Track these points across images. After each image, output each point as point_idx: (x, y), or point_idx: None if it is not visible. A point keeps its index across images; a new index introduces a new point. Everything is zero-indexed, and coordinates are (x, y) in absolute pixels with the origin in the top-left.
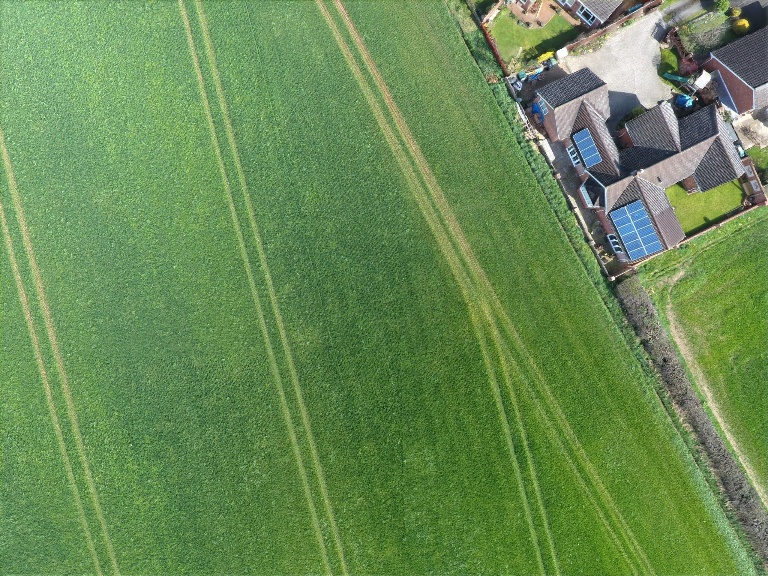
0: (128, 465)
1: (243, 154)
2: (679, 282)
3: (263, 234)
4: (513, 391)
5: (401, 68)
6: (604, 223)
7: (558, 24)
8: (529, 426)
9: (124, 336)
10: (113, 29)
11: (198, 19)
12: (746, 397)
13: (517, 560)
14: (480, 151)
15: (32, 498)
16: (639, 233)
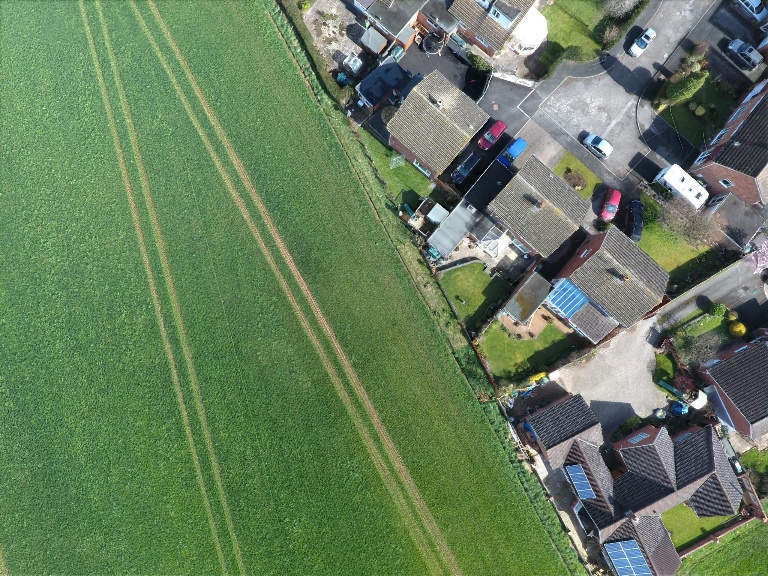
0: None
1: (229, 493)
2: None
3: (250, 575)
4: None
5: (390, 390)
6: None
7: (550, 334)
8: None
9: None
10: (95, 370)
11: (182, 353)
12: None
13: None
14: (471, 472)
15: None
16: (634, 570)
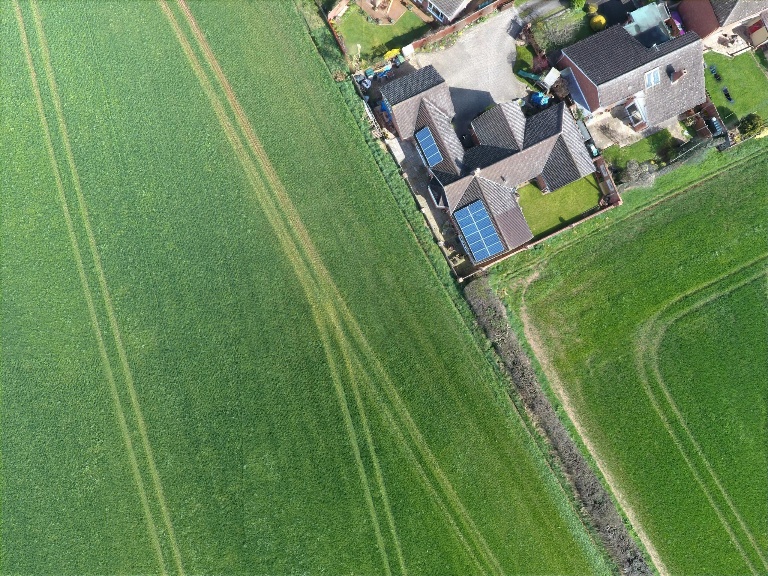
0: None
1: (76, 153)
2: (533, 283)
3: (97, 235)
4: (359, 395)
5: (245, 65)
6: (453, 223)
7: (409, 21)
8: (375, 430)
9: None
10: None
11: (32, 15)
12: (603, 401)
13: (363, 567)
14: (326, 150)
15: None
16: (481, 234)
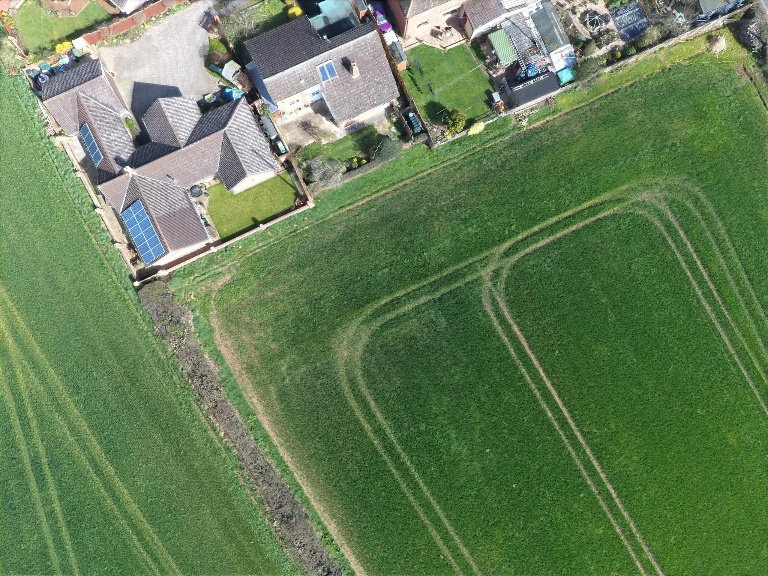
0: None
1: None
2: (223, 287)
3: None
4: (30, 404)
5: None
6: None
7: (93, 13)
8: (47, 442)
9: None
10: None
11: None
12: (301, 409)
13: None
14: None
15: None
16: (145, 235)
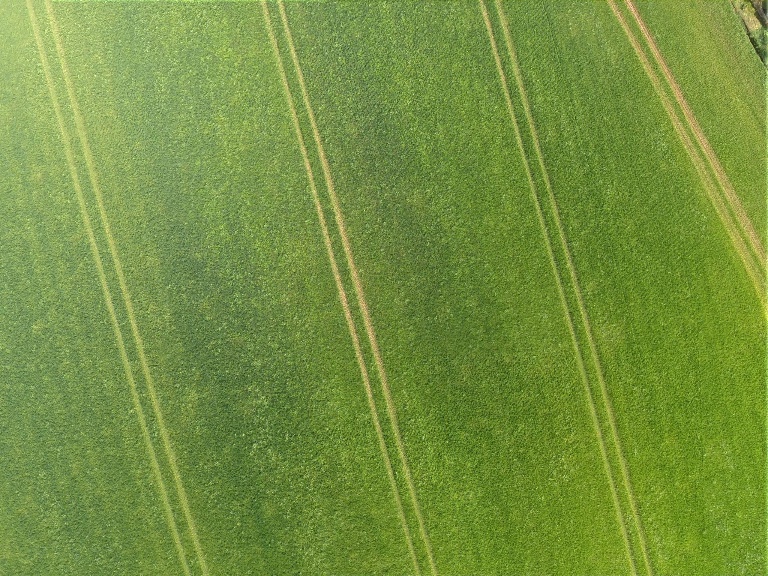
0: (444, 461)
1: (547, 153)
2: None
3: (568, 232)
4: None
5: (691, 66)
6: None
7: None
8: None
9: (440, 334)
10: (420, 31)
11: (499, 20)
12: None
13: None
14: (767, 148)
15: (355, 495)
16: None
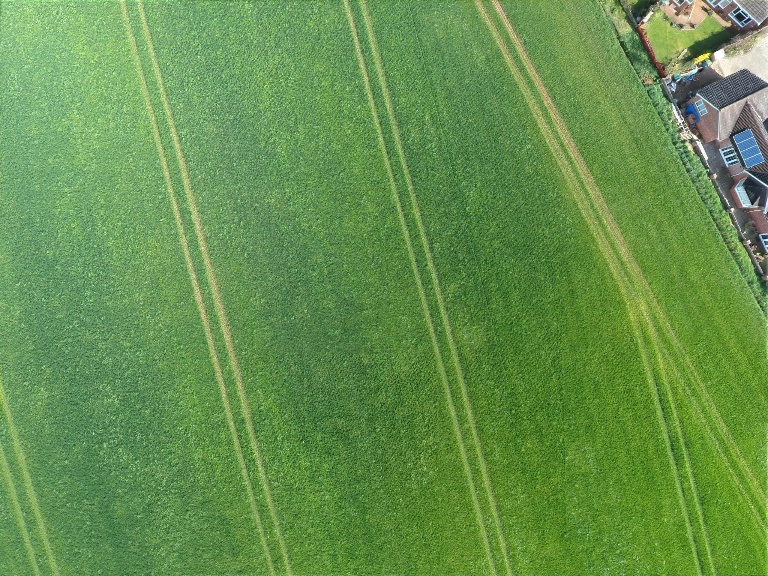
0: (300, 462)
1: (409, 154)
2: None
3: (429, 234)
4: (670, 389)
5: (559, 69)
6: (758, 223)
7: (709, 26)
8: (686, 424)
9: (297, 334)
10: (282, 31)
11: (364, 21)
12: None
13: (674, 556)
14: (636, 151)
15: (208, 495)
16: None
